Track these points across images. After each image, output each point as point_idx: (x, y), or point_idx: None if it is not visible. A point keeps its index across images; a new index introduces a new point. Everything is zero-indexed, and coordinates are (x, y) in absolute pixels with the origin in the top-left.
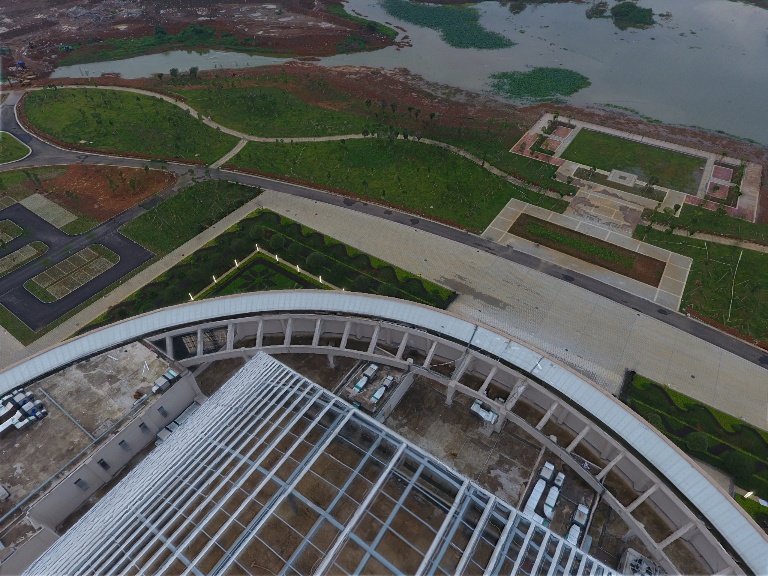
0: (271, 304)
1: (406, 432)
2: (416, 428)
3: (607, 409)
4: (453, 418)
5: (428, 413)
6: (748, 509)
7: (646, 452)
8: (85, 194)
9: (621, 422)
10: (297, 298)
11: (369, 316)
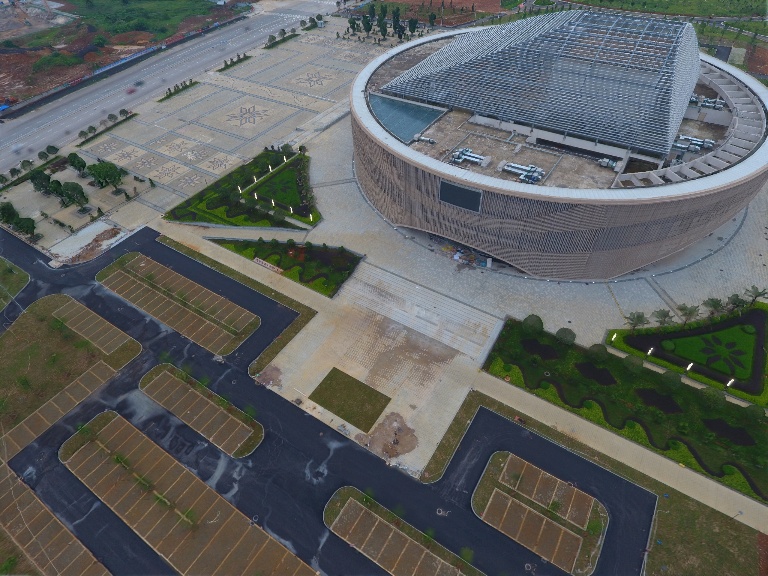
0: (732, 72)
1: (696, 126)
2: (701, 128)
3: (767, 153)
4: (717, 137)
5: (713, 131)
6: (766, 307)
7: None
8: (764, 60)
9: (762, 156)
10: (745, 76)
11: (756, 95)
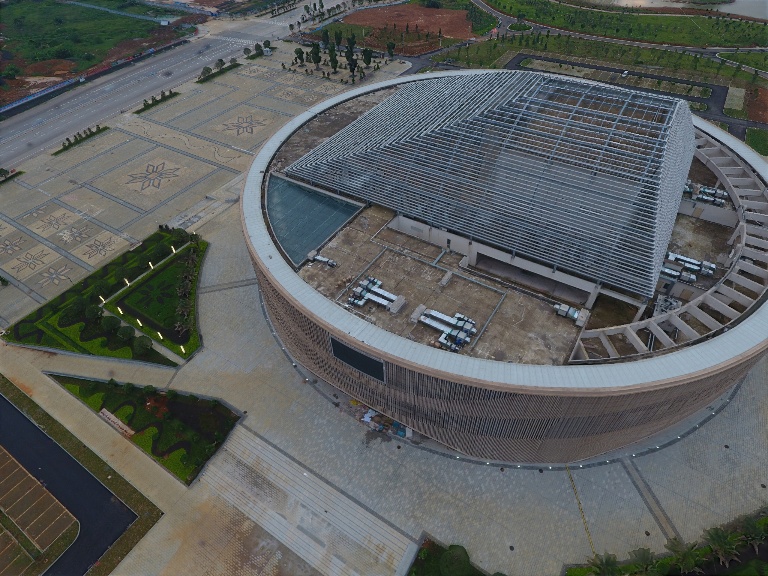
0: (735, 146)
1: (690, 225)
2: (697, 230)
3: None
4: (718, 246)
5: (712, 235)
6: None
7: (765, 309)
8: (767, 105)
9: None
10: (751, 155)
11: (767, 185)
